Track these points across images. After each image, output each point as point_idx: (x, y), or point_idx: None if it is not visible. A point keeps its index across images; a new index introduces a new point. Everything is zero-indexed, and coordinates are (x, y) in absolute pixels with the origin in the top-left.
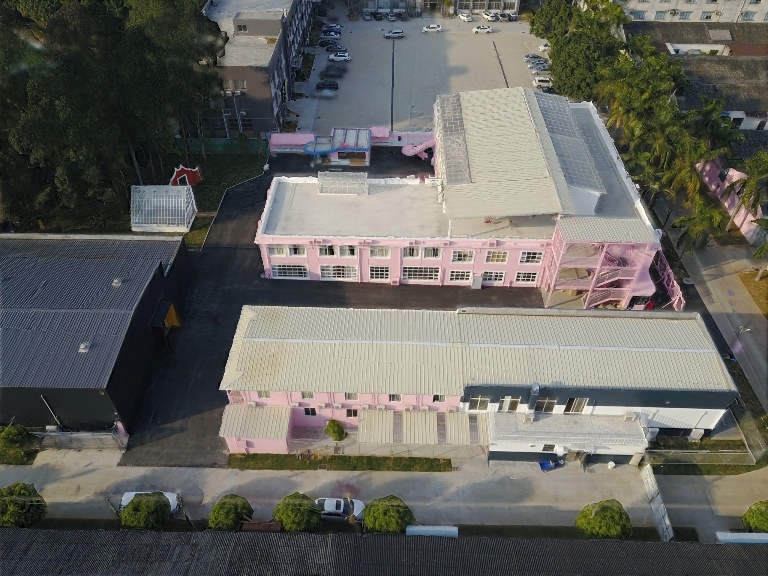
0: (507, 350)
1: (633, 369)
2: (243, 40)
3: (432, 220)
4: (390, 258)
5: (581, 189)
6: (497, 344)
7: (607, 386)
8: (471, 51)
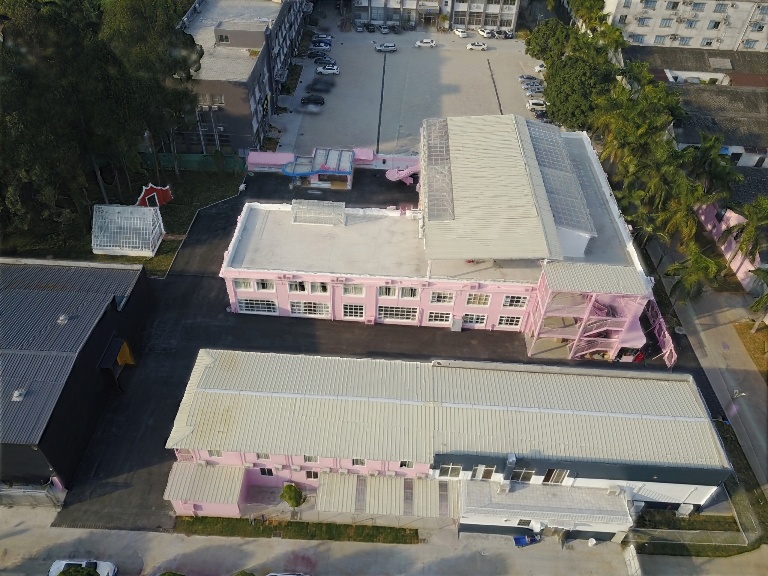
0: (483, 412)
1: (619, 438)
2: (224, 51)
3: (411, 257)
4: (365, 297)
5: (570, 231)
6: (473, 404)
7: (590, 457)
8: (464, 69)
